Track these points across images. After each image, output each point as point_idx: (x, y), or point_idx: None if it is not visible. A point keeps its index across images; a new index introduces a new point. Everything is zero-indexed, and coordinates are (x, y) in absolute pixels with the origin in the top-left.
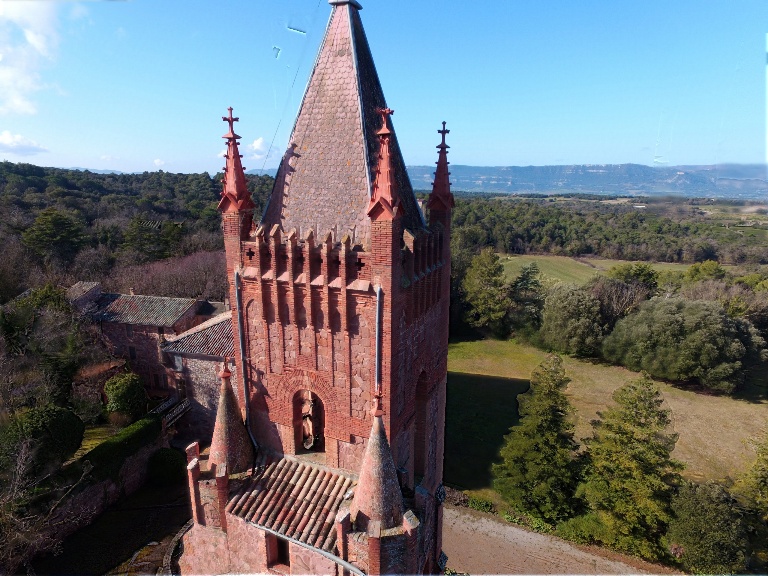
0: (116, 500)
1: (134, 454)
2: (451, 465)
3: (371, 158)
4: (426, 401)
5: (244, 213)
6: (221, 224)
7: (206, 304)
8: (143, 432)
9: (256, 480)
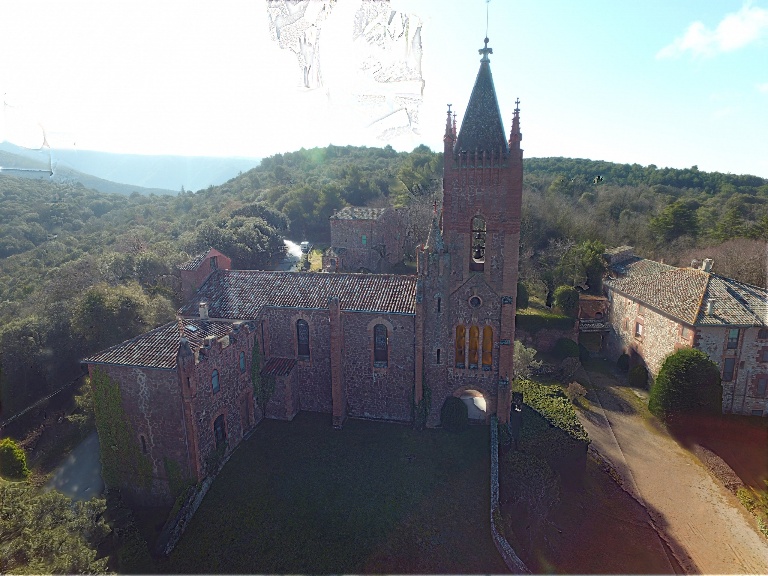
0: None
1: (549, 330)
2: None
3: (466, 121)
4: None
5: None
6: (594, 180)
7: None
8: (560, 321)
9: None
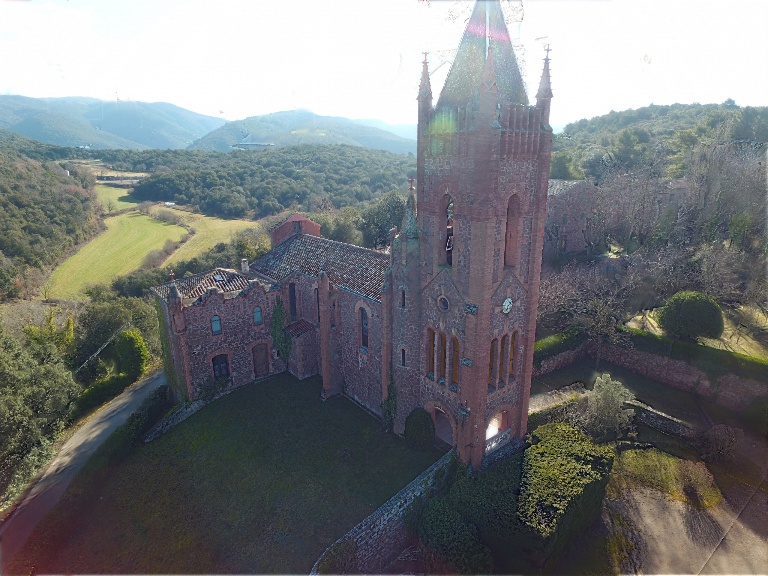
0: (704, 395)
1: (742, 378)
2: None
3: (452, 72)
4: None
5: None
6: None
7: None
8: (767, 370)
9: None
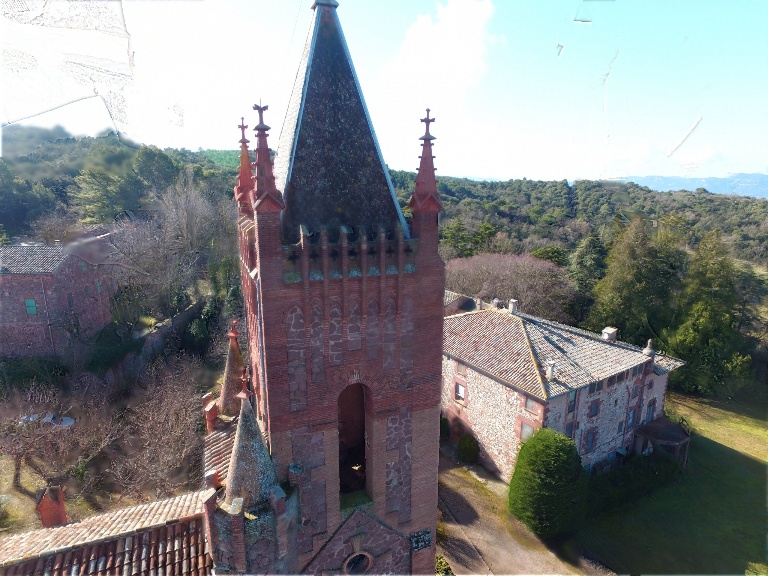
0: None
1: None
2: (670, 572)
3: (301, 154)
4: (372, 419)
5: (243, 204)
6: None
7: (471, 301)
8: None
9: (232, 426)
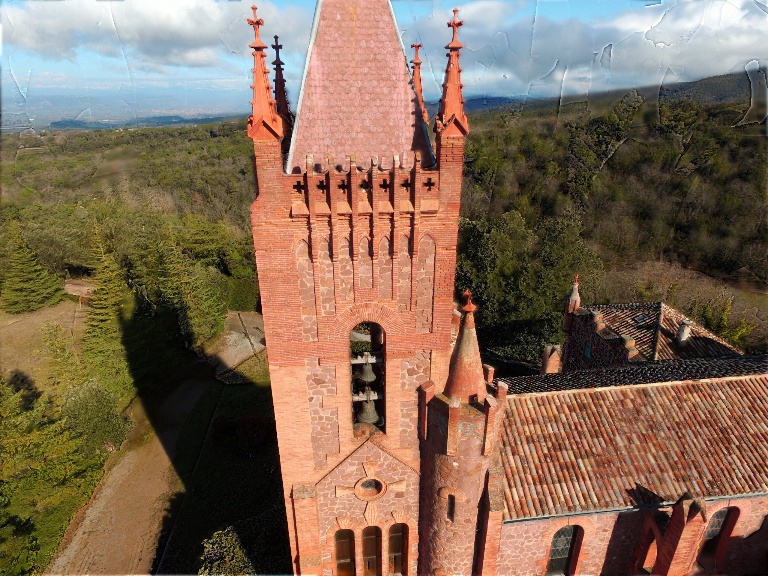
0: None
1: None
2: None
3: None
4: None
5: None
6: None
7: None
8: None
9: None
